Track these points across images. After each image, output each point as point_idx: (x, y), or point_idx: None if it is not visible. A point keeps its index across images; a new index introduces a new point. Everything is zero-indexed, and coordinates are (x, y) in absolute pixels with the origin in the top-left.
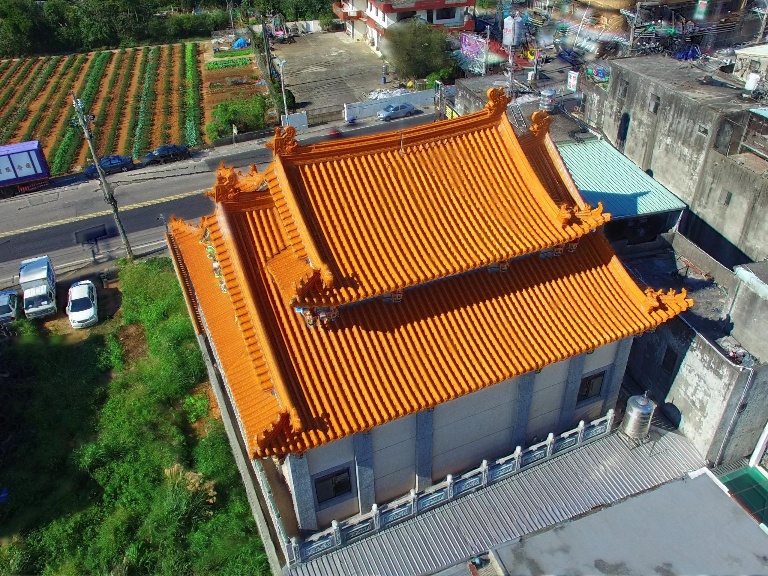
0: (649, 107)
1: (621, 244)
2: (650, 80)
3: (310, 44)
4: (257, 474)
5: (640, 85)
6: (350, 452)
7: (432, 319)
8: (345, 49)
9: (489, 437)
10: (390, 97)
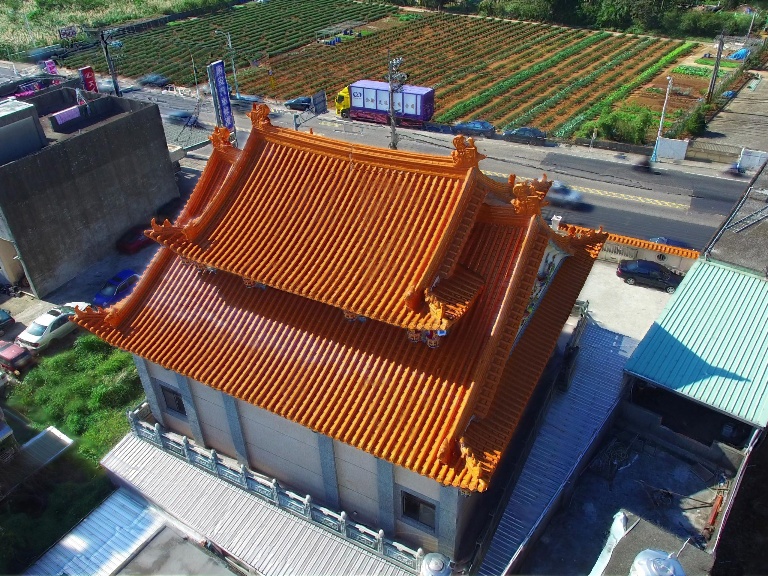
0: None
1: (650, 416)
2: None
3: None
4: None
5: None
6: None
7: (266, 319)
8: None
9: (302, 469)
10: None
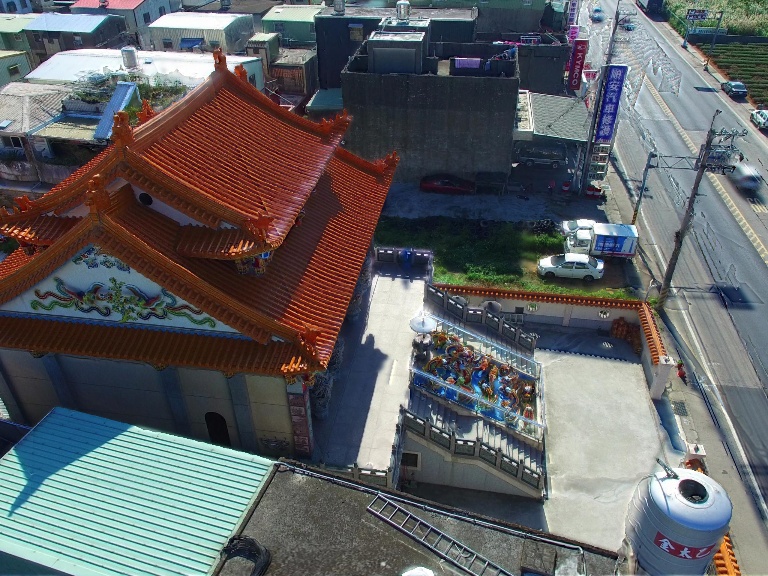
0: None
1: None
2: None
3: None
4: None
5: None
6: None
7: None
8: None
9: None
10: None
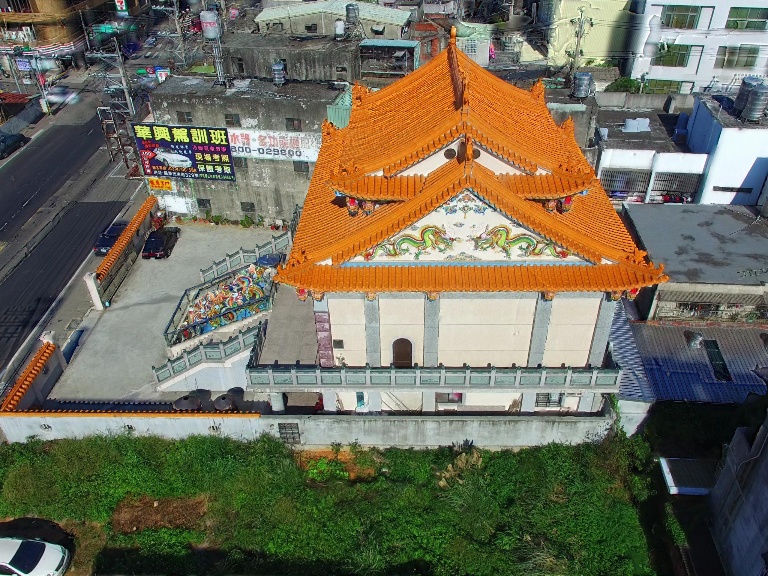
0: None
1: None
2: (268, 49)
3: None
4: (526, 387)
5: (258, 56)
6: None
7: None
8: None
9: None
10: None
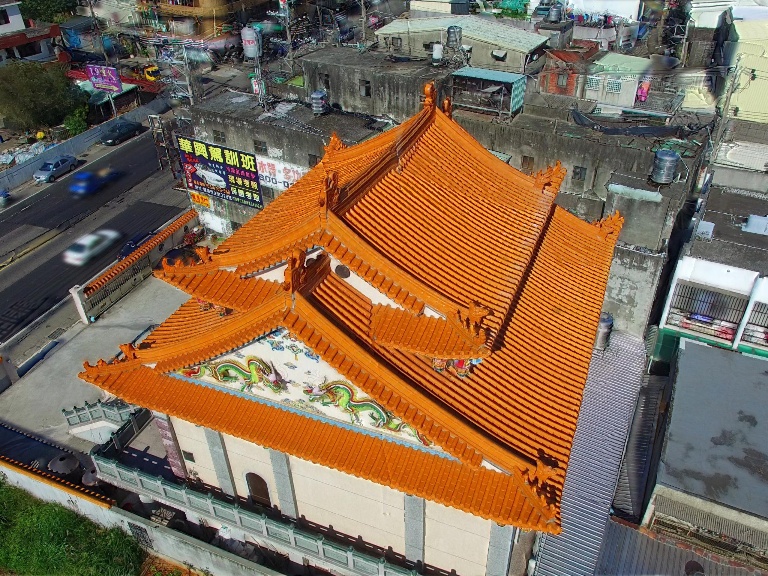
0: (360, 92)
1: None
2: (353, 68)
3: None
4: None
5: (344, 75)
6: None
7: (514, 318)
8: None
9: None
10: (39, 154)
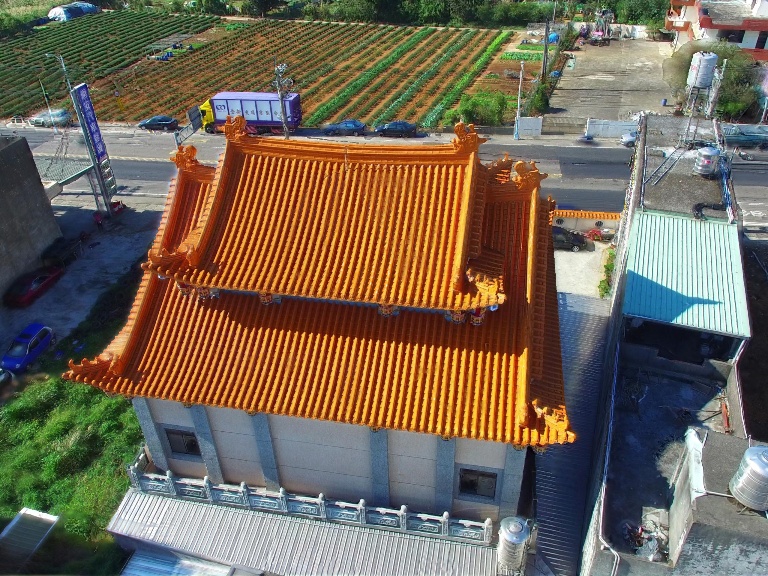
0: None
1: (647, 351)
2: None
3: (621, 50)
4: None
5: None
6: (192, 419)
7: (293, 333)
8: (654, 61)
9: (345, 476)
10: None
